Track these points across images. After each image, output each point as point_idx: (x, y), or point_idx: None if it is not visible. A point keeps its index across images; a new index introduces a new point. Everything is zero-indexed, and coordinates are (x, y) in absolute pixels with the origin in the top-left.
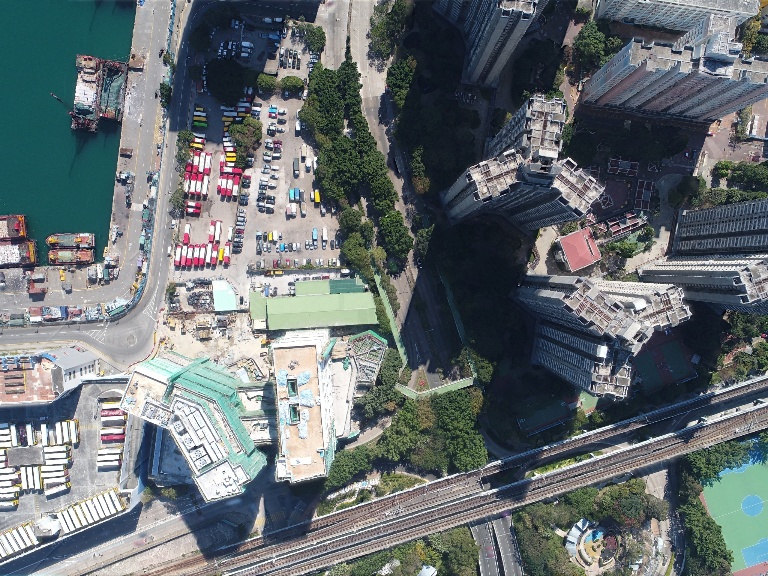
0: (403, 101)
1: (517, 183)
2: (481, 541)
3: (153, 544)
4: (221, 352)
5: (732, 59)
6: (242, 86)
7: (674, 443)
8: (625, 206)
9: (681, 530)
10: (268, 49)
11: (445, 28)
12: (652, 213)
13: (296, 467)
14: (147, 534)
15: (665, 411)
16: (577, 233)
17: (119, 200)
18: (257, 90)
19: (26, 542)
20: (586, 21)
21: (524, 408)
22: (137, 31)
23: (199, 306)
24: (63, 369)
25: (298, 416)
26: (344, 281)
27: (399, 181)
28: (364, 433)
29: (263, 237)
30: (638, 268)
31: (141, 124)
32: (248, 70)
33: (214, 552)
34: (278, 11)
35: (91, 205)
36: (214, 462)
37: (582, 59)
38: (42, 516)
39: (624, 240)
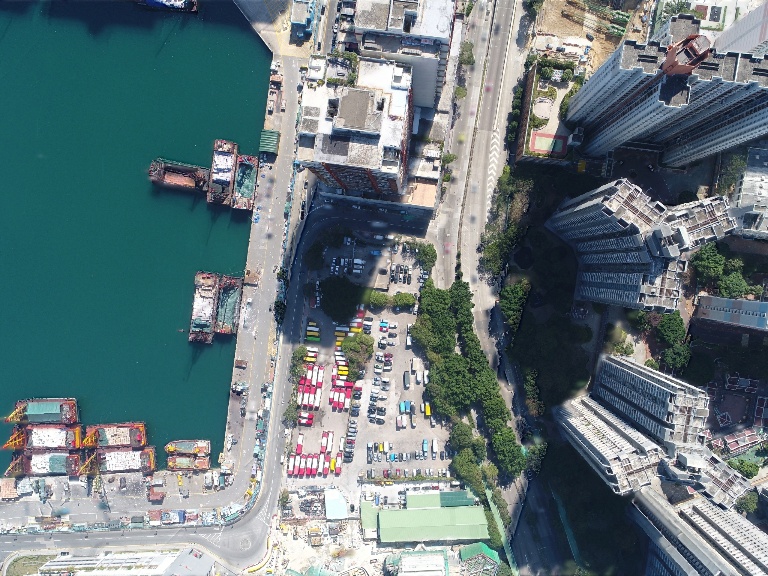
0: (517, 325)
1: (658, 476)
2: None
3: None
4: (332, 557)
5: None
6: (355, 305)
7: None
8: (743, 421)
9: None
10: (379, 264)
11: (556, 243)
12: None
13: None
14: None
15: None
16: None
17: (234, 409)
18: (368, 305)
19: None
20: None
21: None
22: (252, 247)
23: (311, 513)
24: None
25: None
26: (455, 494)
27: (509, 393)
28: None
29: (374, 447)
30: (757, 486)
31: (255, 337)
32: (361, 289)
33: None
34: (389, 227)
35: (207, 413)
36: None
37: (700, 279)
38: None
39: (742, 455)
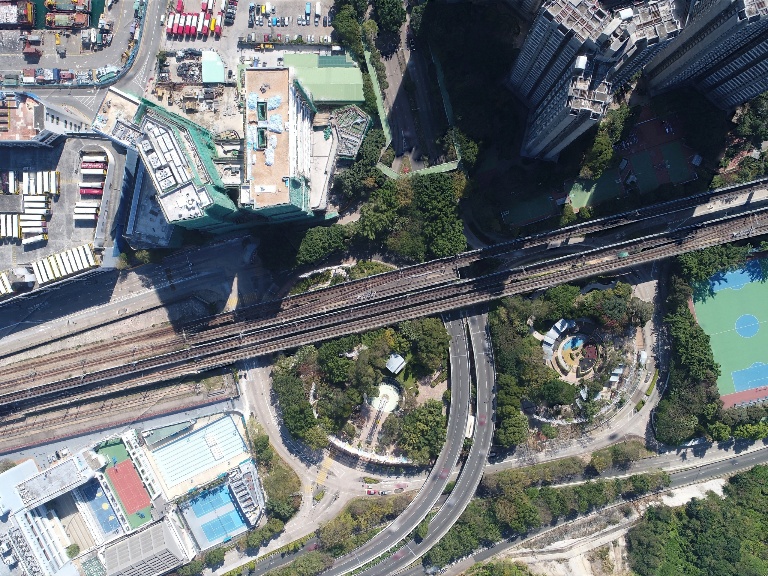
0: None
1: None
2: (454, 338)
3: (125, 315)
4: (206, 126)
5: None
6: None
7: (665, 243)
8: None
9: (667, 346)
10: None
11: None
12: None
13: (260, 195)
14: (121, 306)
15: (658, 208)
16: None
17: None
18: None
19: (1, 289)
20: None
21: (508, 196)
22: None
23: (188, 77)
24: (45, 106)
25: (266, 141)
26: (334, 57)
27: None
28: (343, 218)
29: (256, 10)
30: None
31: None
32: None
33: (183, 324)
34: None
35: None
36: (179, 183)
37: None
38: (18, 267)
39: None
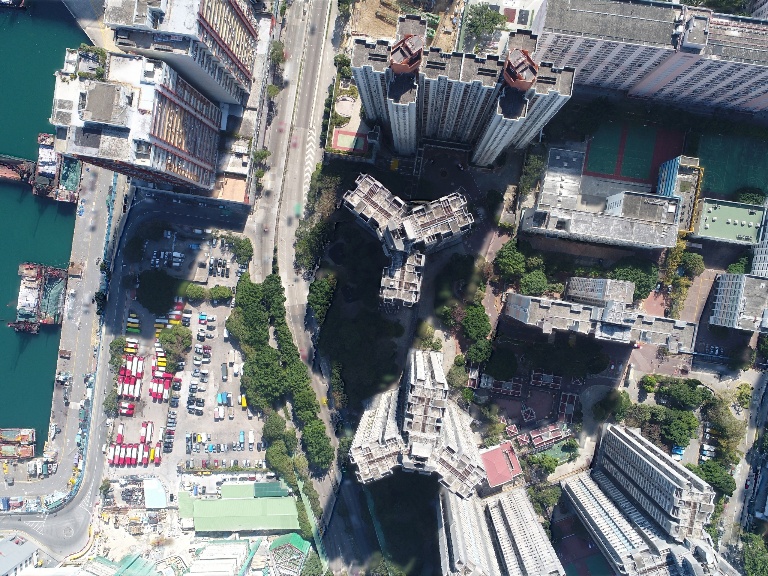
0: (323, 319)
1: None
2: None
3: None
4: (152, 546)
5: (629, 325)
6: (172, 297)
7: None
8: (549, 416)
9: None
10: (199, 258)
11: (369, 239)
12: (575, 428)
13: None
14: None
15: None
16: (496, 449)
17: (58, 399)
18: (188, 298)
19: None
20: (510, 233)
21: None
22: None
23: (132, 502)
24: None
25: None
26: (269, 484)
27: (324, 386)
28: None
29: (192, 438)
30: (561, 480)
31: (79, 328)
32: (177, 282)
33: None
34: (209, 221)
35: (33, 402)
36: None
37: (503, 276)
38: None
39: (548, 450)
